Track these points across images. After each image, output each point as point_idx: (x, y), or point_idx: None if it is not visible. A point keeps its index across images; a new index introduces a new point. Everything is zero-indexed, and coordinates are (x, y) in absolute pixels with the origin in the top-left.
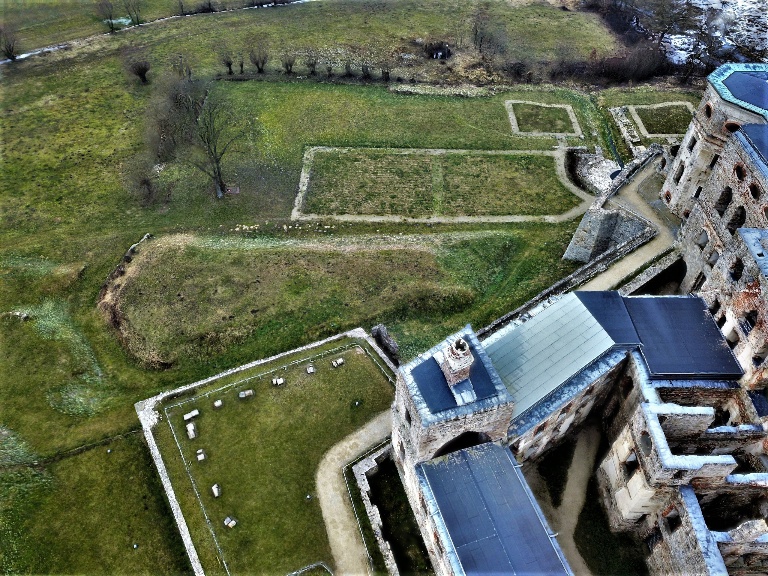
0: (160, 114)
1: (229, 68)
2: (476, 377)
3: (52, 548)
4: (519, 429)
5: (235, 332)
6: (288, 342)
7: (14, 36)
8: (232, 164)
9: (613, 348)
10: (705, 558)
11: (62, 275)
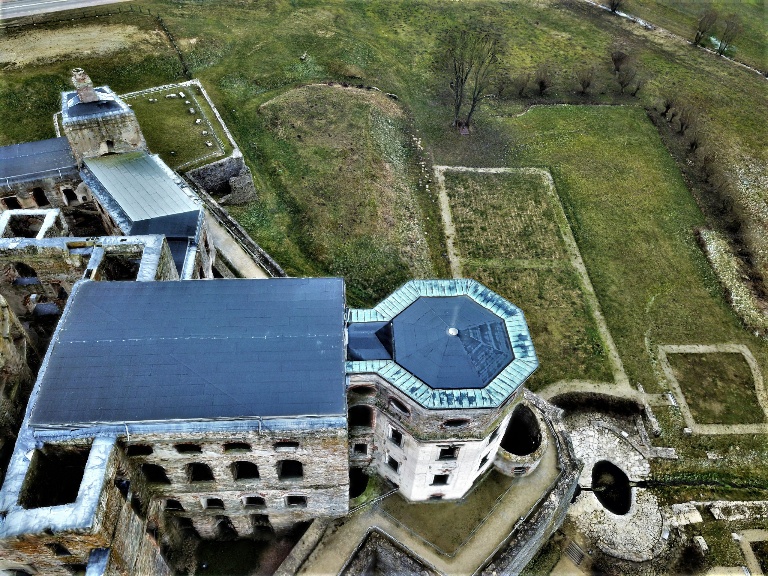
0: (545, 75)
1: (666, 110)
2: (84, 107)
3: (133, 83)
4: (84, 173)
5: (281, 131)
6: (270, 154)
7: (650, 4)
8: (502, 128)
9: None
10: None
11: (347, 69)
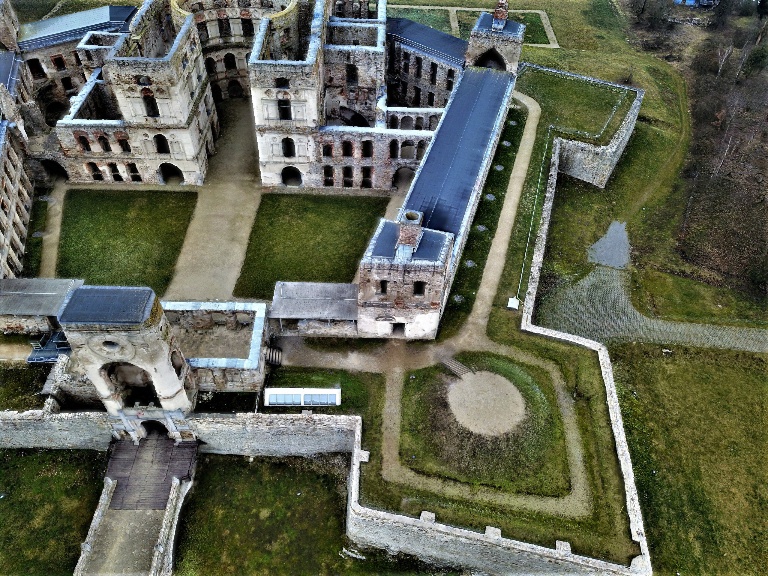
0: None
1: None
2: None
3: None
4: (29, 48)
5: None
6: None
7: None
8: None
9: (110, 25)
10: (84, 86)
11: None
